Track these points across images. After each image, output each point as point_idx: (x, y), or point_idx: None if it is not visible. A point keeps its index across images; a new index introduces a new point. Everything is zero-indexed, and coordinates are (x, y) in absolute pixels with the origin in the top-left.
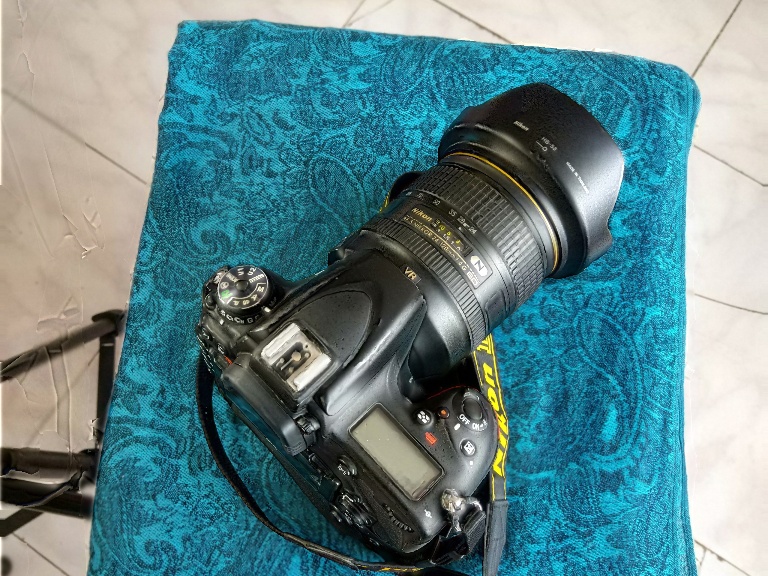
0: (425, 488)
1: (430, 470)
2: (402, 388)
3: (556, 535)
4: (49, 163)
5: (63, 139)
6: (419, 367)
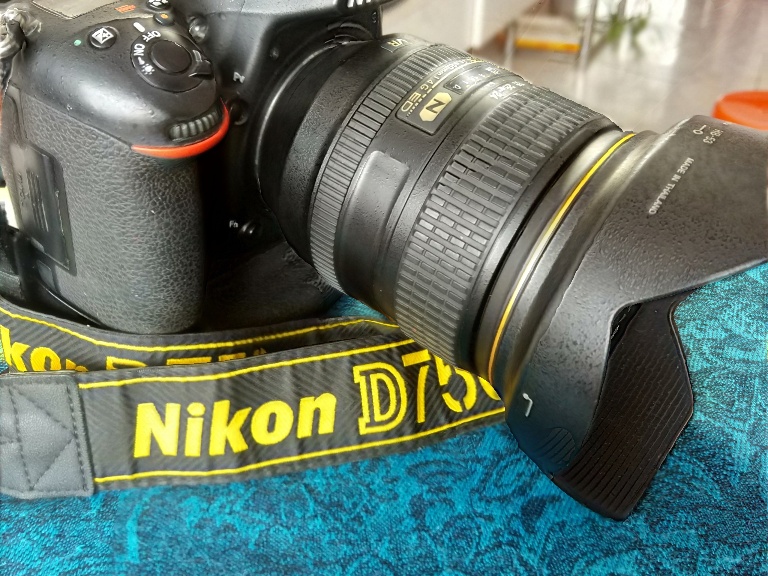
0: None
1: None
2: (222, 55)
3: (9, 572)
4: None
5: None
6: None
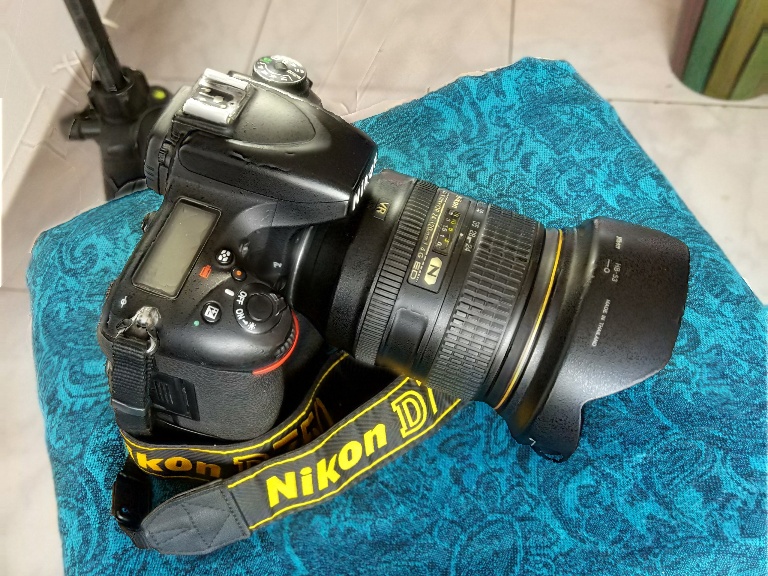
0: (150, 288)
1: (173, 289)
2: (261, 253)
3: None
4: (392, 59)
5: (419, 59)
6: (306, 288)
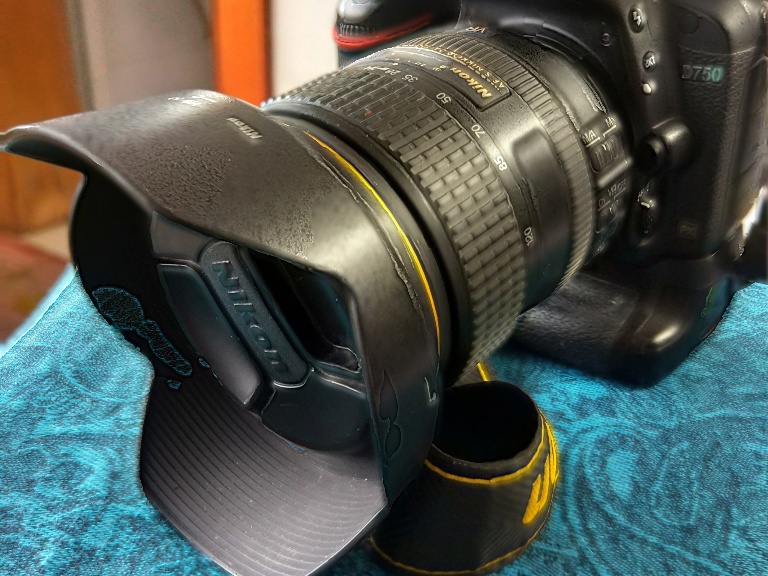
0: None
1: None
2: None
3: None
4: None
5: None
6: None
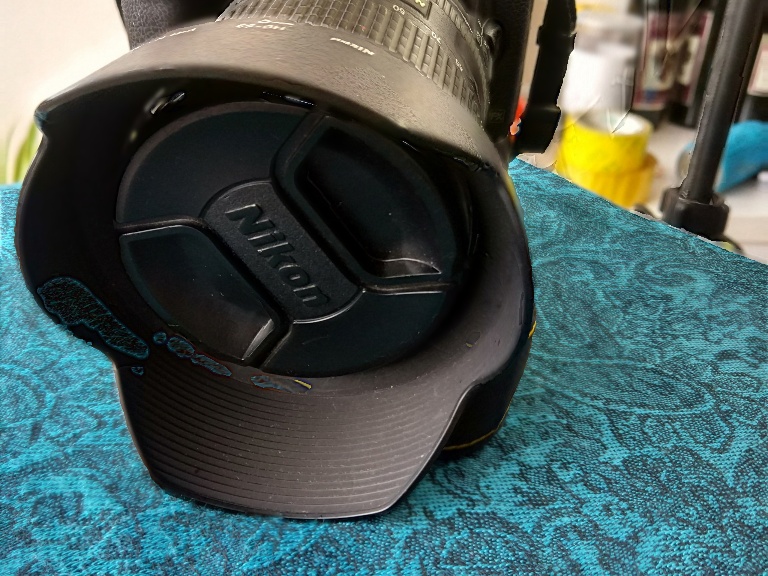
0: None
1: None
2: None
3: None
4: None
5: None
6: None
